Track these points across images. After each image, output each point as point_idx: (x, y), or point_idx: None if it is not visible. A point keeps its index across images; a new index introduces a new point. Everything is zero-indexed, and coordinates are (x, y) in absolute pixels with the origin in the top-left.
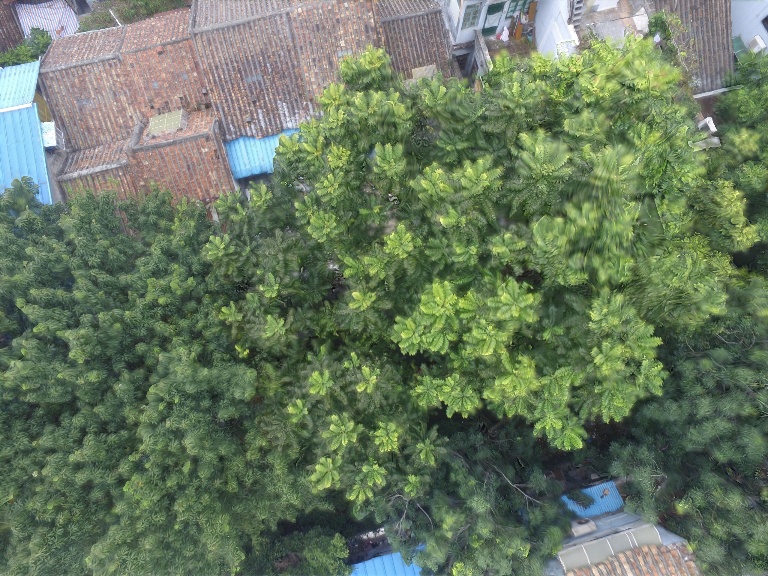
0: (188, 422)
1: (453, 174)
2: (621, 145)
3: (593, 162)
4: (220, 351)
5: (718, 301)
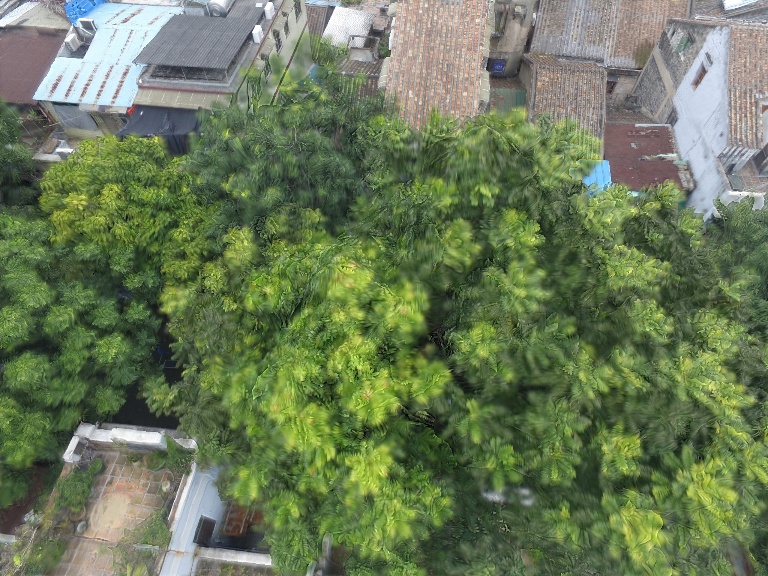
0: None
1: (589, 246)
2: (373, 243)
3: (495, 131)
4: (764, 340)
5: (282, 211)
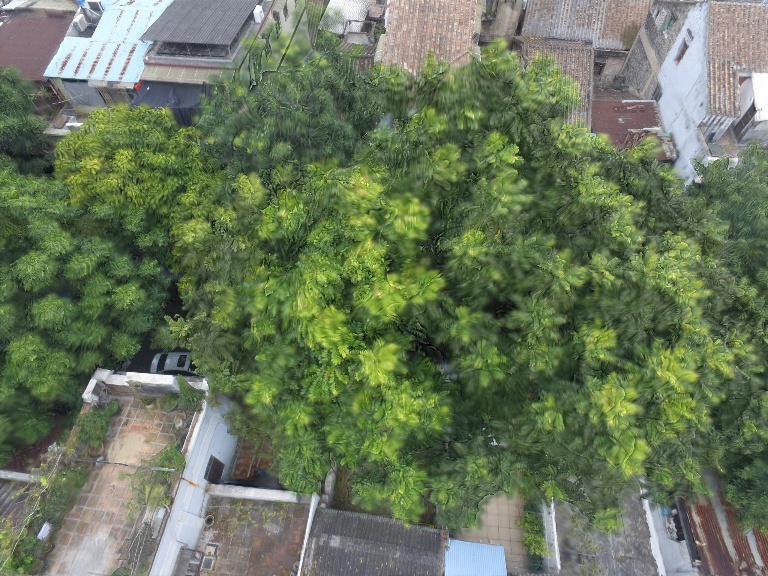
0: (766, 206)
1: (562, 165)
2: (370, 169)
3: None
4: None
5: (285, 166)
